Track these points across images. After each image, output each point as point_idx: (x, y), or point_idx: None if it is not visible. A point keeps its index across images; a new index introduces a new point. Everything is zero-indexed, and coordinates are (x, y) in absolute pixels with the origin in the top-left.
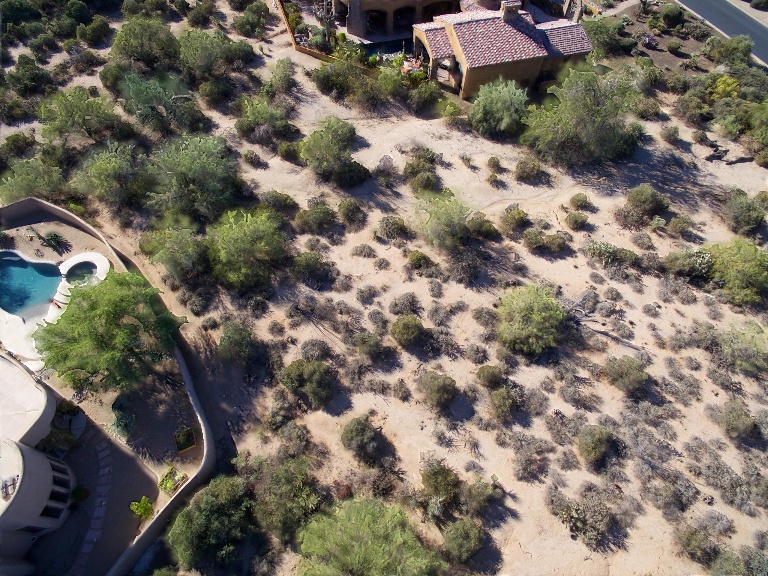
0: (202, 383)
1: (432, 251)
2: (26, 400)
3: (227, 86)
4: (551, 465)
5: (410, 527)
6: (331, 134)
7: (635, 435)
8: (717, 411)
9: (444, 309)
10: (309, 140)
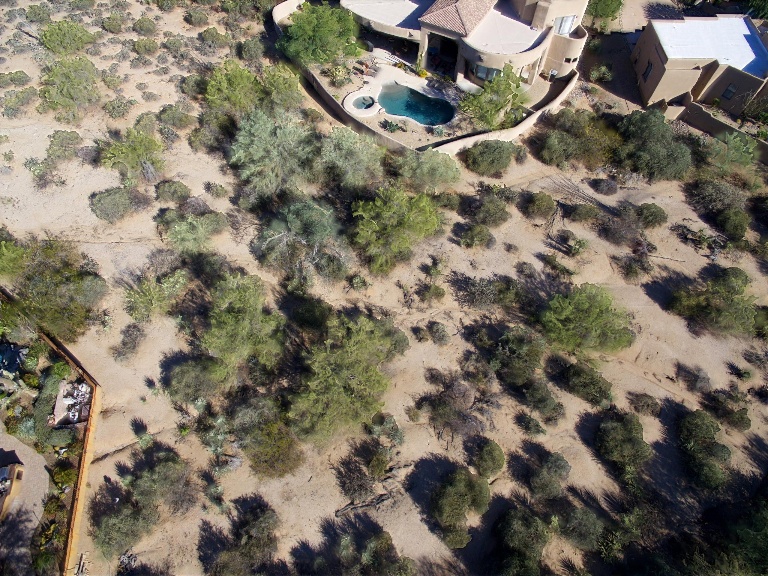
0: (282, 52)
1: (100, 91)
2: (354, 8)
3: None
4: (112, 6)
5: (191, 0)
6: (123, 192)
7: (62, 4)
8: (11, 4)
9: (117, 55)
10: (144, 142)
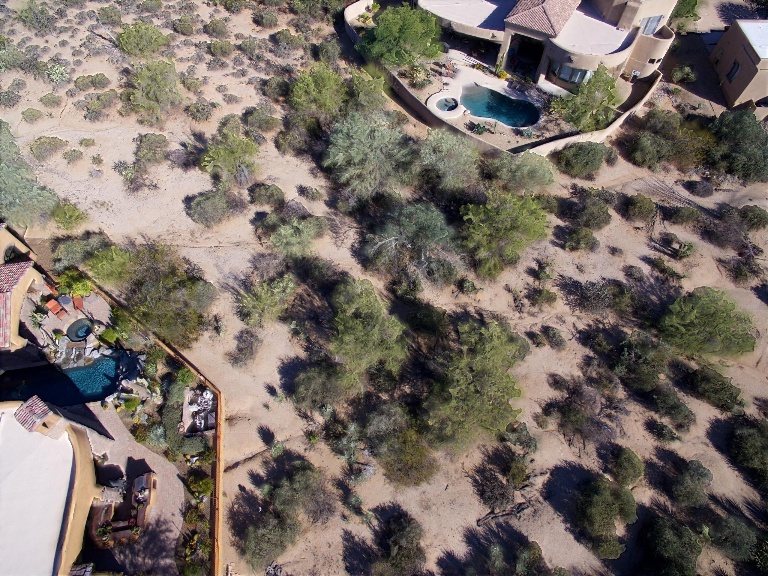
0: (355, 53)
1: (180, 93)
2: (432, 9)
3: (336, 294)
4: None
5: None
6: (220, 196)
7: (130, 6)
8: None
9: (193, 58)
10: (242, 145)
